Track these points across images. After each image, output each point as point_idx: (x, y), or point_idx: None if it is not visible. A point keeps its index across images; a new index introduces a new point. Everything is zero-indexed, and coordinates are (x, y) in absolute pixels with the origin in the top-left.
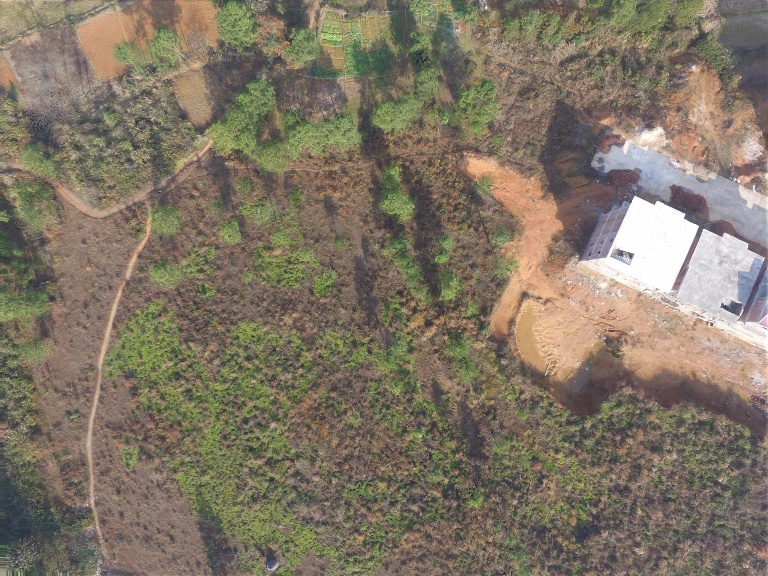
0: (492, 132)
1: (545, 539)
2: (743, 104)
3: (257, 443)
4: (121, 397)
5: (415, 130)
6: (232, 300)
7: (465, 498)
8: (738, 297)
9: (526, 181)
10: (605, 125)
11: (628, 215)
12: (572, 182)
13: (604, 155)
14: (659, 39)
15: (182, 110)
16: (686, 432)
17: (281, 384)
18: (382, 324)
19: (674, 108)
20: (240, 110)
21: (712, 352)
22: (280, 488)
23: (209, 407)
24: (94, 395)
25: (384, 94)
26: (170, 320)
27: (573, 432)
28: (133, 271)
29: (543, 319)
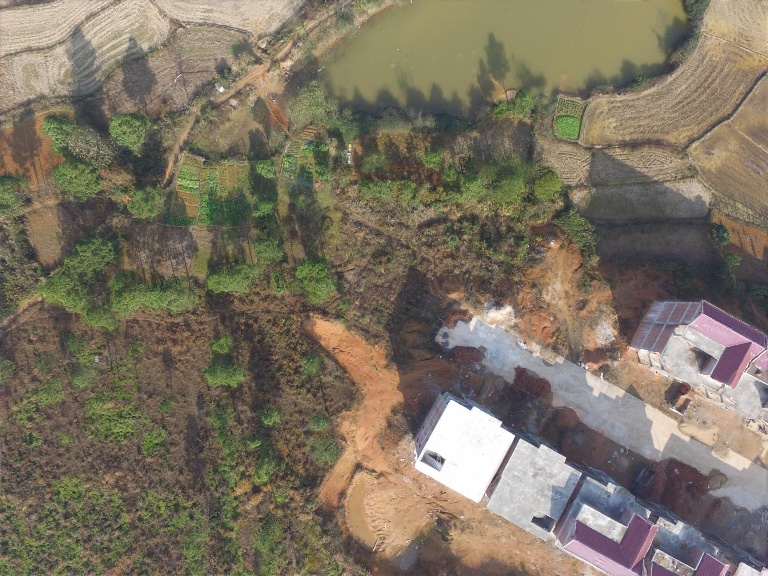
0: (341, 294)
1: None
2: (600, 285)
3: None
4: None
5: (262, 287)
6: (57, 453)
7: None
8: (550, 512)
9: (371, 348)
10: (453, 299)
11: (442, 419)
12: (416, 354)
13: (449, 330)
14: (521, 209)
15: (31, 248)
16: None
17: (97, 545)
18: (207, 488)
19: (529, 283)
20: (64, 274)
21: (543, 544)
22: None
23: (22, 563)
24: None
25: (236, 246)
26: None
27: None
28: None
29: (375, 493)
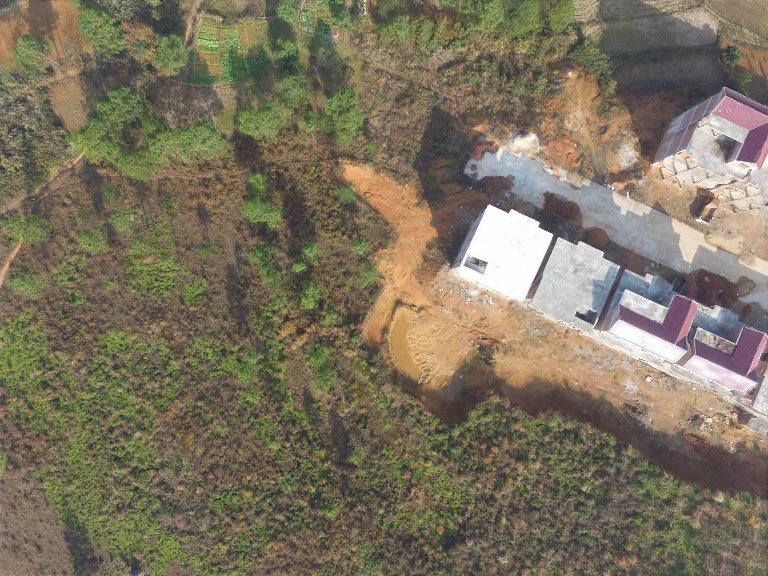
0: (368, 139)
1: (410, 548)
2: (619, 110)
3: (122, 452)
4: None
5: (290, 137)
6: (101, 309)
7: (331, 507)
8: (593, 306)
9: (401, 188)
10: (479, 132)
11: (482, 223)
12: (446, 189)
13: (477, 162)
14: (537, 45)
15: (57, 117)
16: (551, 441)
17: (148, 393)
18: (252, 332)
19: (551, 114)
20: (98, 118)
21: (584, 360)
22: (145, 498)
23: (75, 416)
24: None
25: (260, 101)
26: (39, 329)
27: (442, 441)
28: (5, 279)
29: (417, 327)
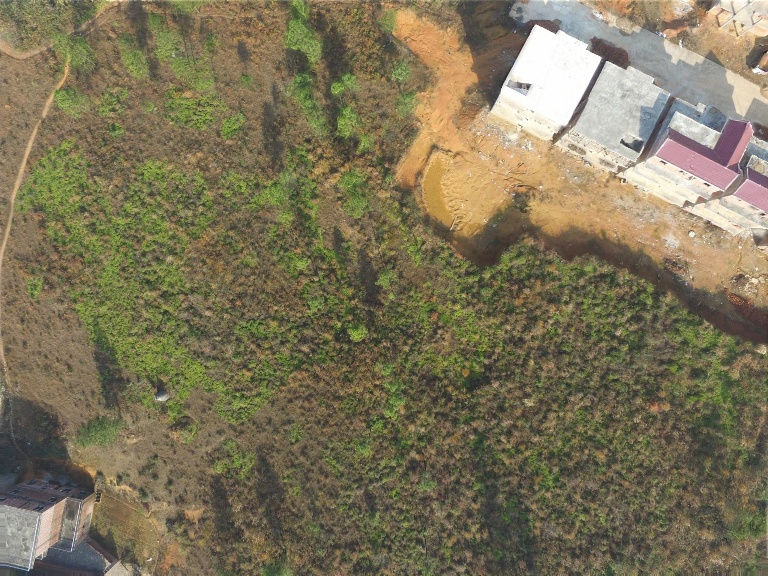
0: None
1: (434, 387)
2: None
3: (153, 276)
4: (30, 230)
5: None
6: (140, 138)
7: (356, 342)
8: (639, 133)
9: (443, 33)
10: None
11: (527, 44)
12: (489, 33)
13: (523, 5)
14: None
15: None
16: (586, 284)
17: (181, 221)
18: (286, 169)
19: None
20: None
21: (624, 211)
22: (173, 321)
23: (110, 240)
24: (6, 228)
25: None
26: (80, 156)
27: (471, 283)
28: (49, 110)
29: (452, 173)
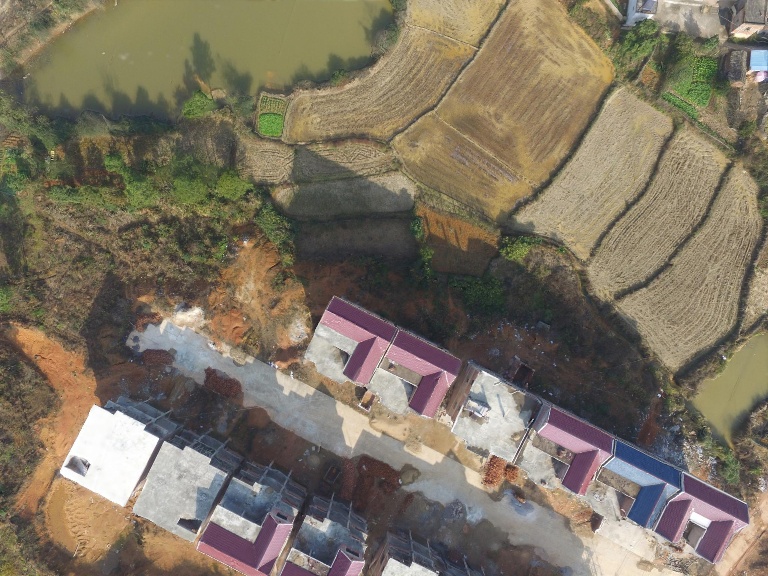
0: (41, 301)
1: None
2: (293, 283)
3: None
4: None
5: None
6: None
7: None
8: (196, 514)
9: (69, 354)
10: (144, 302)
11: (86, 424)
12: (110, 359)
13: (140, 334)
14: (217, 210)
15: None
16: None
17: None
18: None
19: (224, 284)
20: None
21: None
22: None
23: None
24: None
25: None
26: None
27: None
28: None
29: (75, 498)
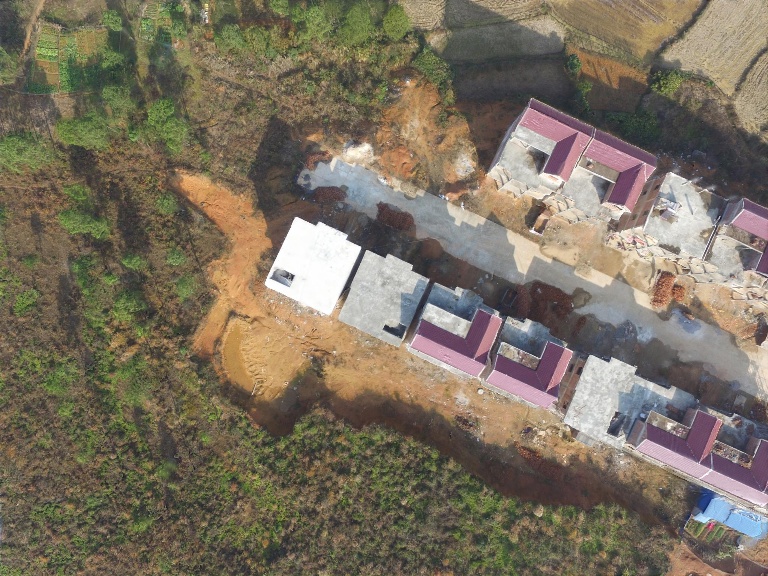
0: (205, 148)
1: (232, 562)
2: (457, 119)
3: None
4: None
5: (126, 146)
6: None
7: (154, 520)
8: (401, 319)
9: (237, 198)
10: (313, 141)
11: (289, 236)
12: (281, 199)
13: (310, 172)
14: (377, 53)
15: None
16: (373, 454)
17: None
18: (82, 344)
19: (389, 123)
20: None
21: (416, 372)
22: None
23: None
24: None
25: (98, 110)
26: None
27: (268, 453)
28: None
29: (250, 338)
